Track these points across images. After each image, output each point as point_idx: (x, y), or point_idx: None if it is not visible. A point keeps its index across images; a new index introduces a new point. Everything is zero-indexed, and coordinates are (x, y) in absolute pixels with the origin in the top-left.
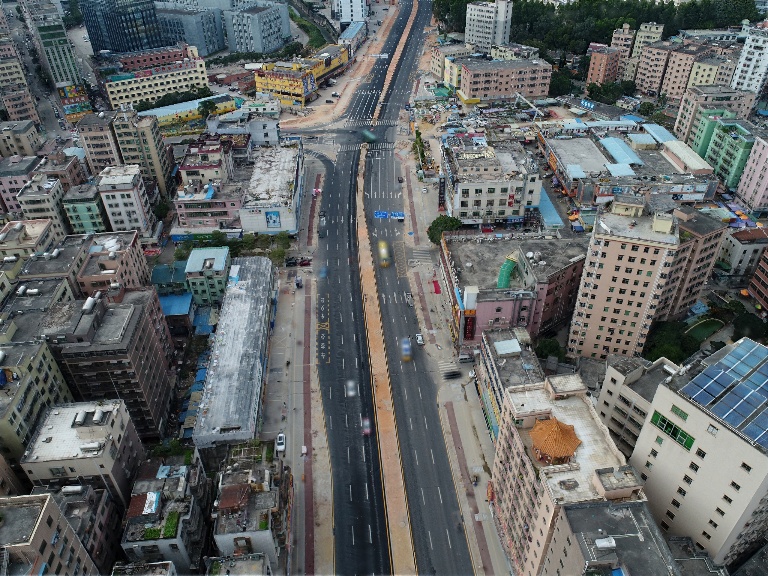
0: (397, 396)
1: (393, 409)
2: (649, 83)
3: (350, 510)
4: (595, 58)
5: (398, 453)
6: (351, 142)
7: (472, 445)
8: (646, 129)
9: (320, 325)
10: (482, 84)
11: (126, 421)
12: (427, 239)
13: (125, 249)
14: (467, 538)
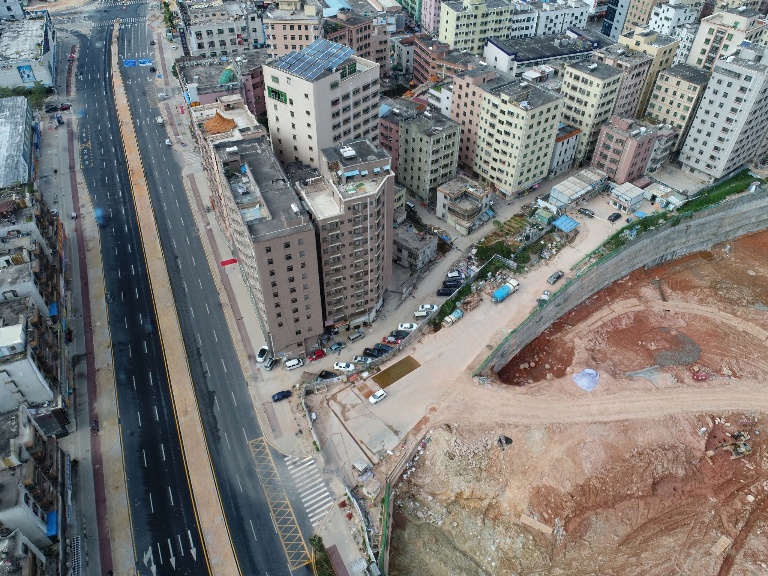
0: (150, 176)
1: (146, 184)
2: None
3: (113, 240)
4: None
5: (150, 205)
6: (104, 19)
7: (207, 193)
8: None
9: (82, 145)
10: None
11: None
12: (176, 81)
13: None
14: (201, 238)
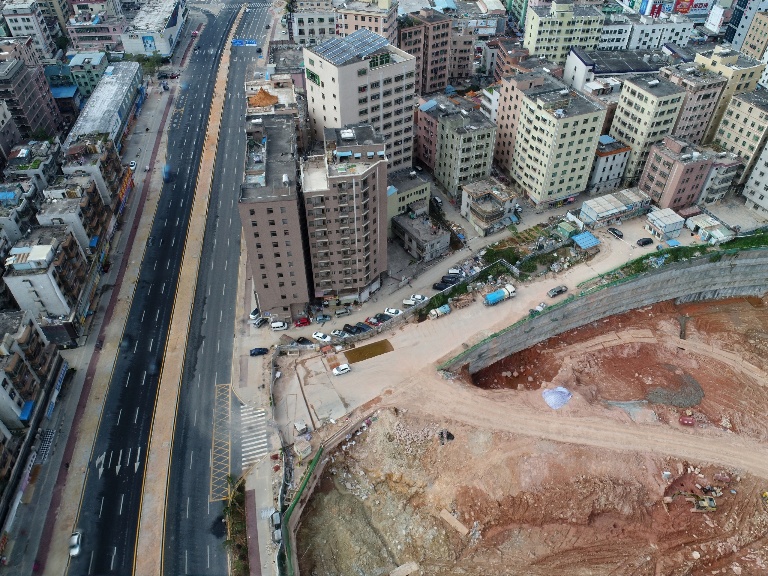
0: (221, 144)
1: (216, 150)
2: None
3: (172, 194)
4: None
5: (212, 169)
6: (235, 2)
7: None
8: None
9: (177, 110)
10: None
11: (8, 117)
12: None
13: (21, 46)
14: None
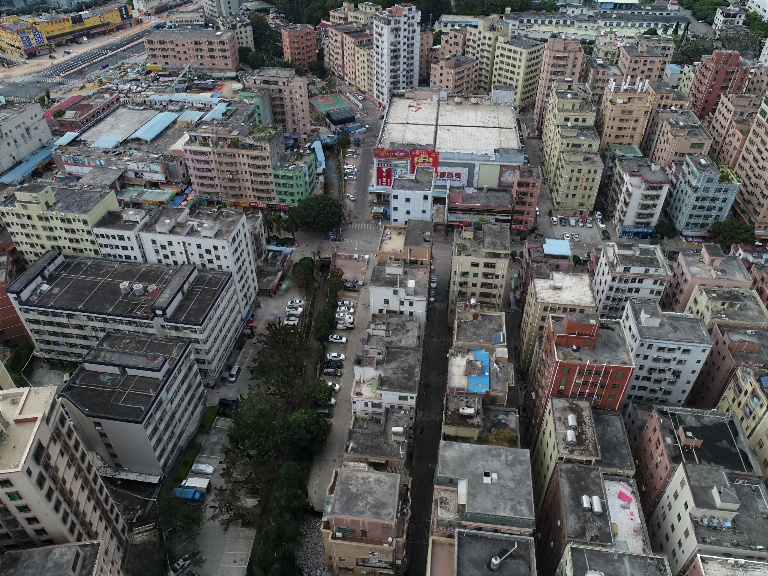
0: None
1: None
2: (336, 66)
3: None
4: (283, 35)
5: None
6: (3, 95)
7: None
8: (214, 108)
9: None
10: (159, 51)
11: None
12: None
13: None
14: None
